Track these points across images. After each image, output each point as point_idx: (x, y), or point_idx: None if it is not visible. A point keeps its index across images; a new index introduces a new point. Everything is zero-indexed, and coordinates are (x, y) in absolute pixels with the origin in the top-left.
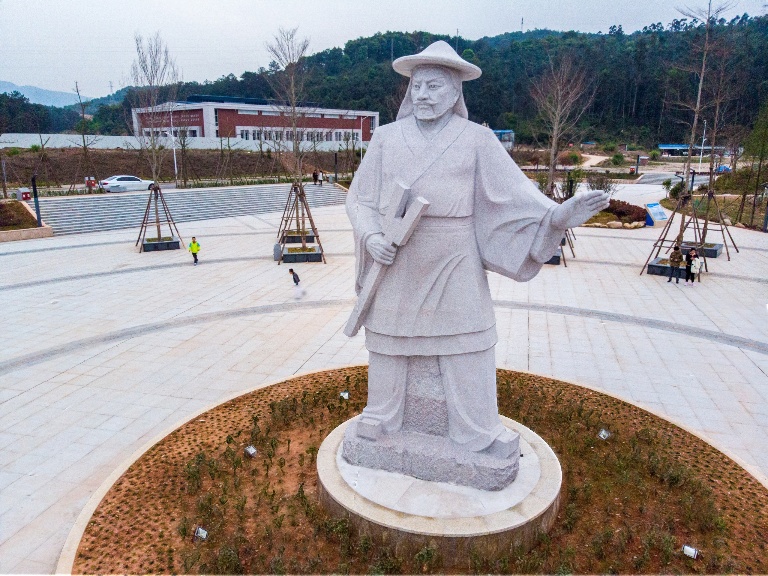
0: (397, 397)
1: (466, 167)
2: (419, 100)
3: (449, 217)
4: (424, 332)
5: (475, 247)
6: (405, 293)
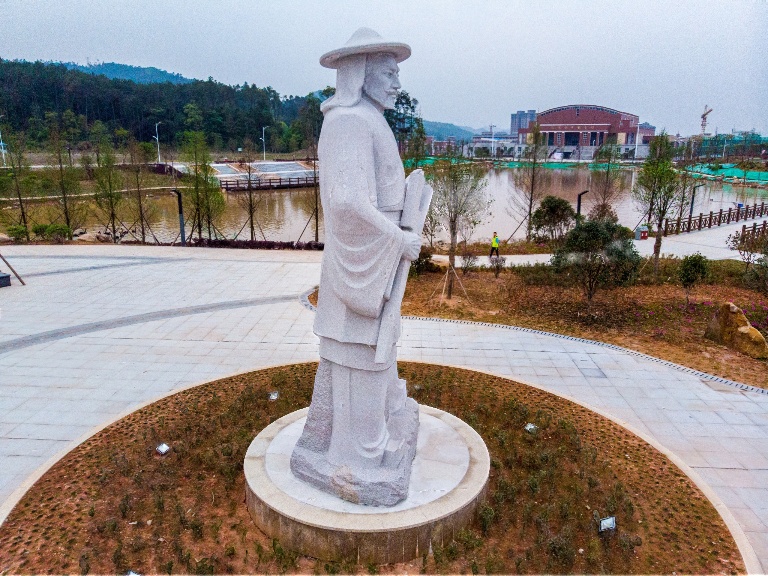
0: None
1: None
2: (397, 89)
3: None
4: None
5: None
6: None
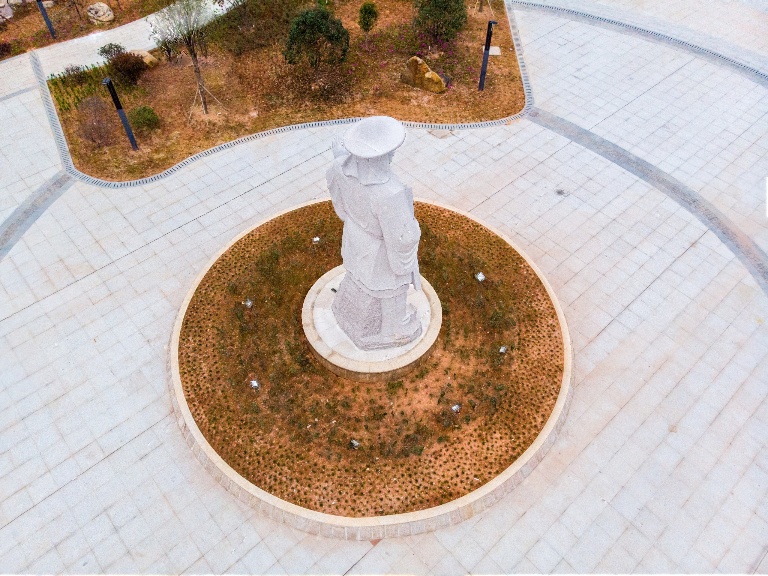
0: None
1: None
2: None
3: None
4: None
5: None
6: None
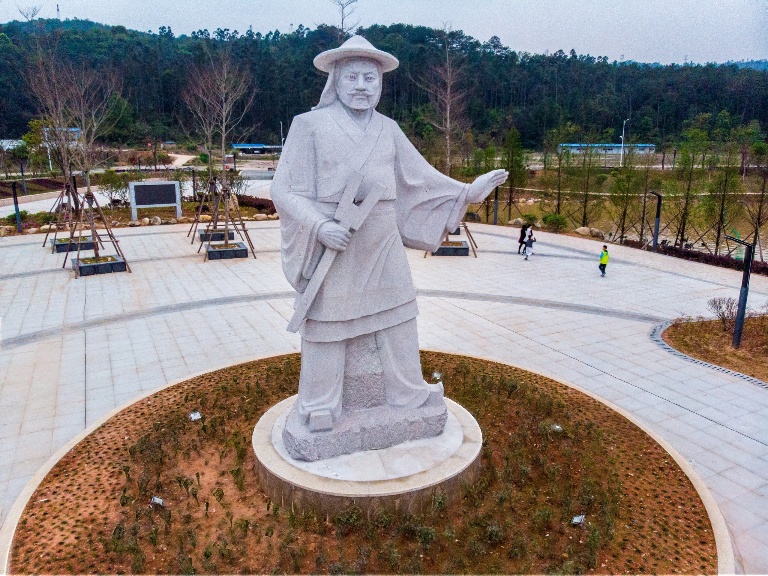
0: (339, 382)
1: (394, 154)
2: (358, 90)
3: (388, 200)
4: (368, 311)
5: (397, 226)
6: (351, 277)
